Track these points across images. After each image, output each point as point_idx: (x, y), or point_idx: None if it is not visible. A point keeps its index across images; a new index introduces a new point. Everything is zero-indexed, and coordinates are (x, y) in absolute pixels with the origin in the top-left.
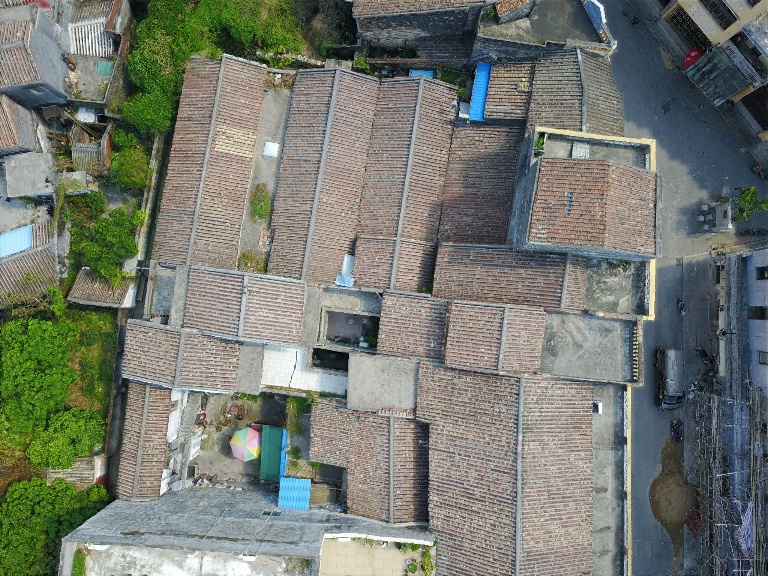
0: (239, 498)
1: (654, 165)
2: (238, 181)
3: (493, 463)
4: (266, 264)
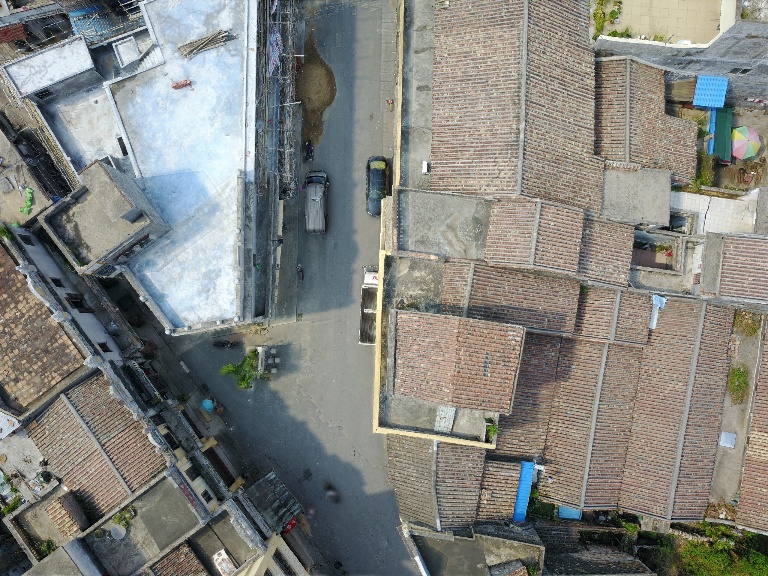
0: (760, 89)
1: (375, 406)
2: (767, 407)
3: (544, 113)
4: (733, 321)
